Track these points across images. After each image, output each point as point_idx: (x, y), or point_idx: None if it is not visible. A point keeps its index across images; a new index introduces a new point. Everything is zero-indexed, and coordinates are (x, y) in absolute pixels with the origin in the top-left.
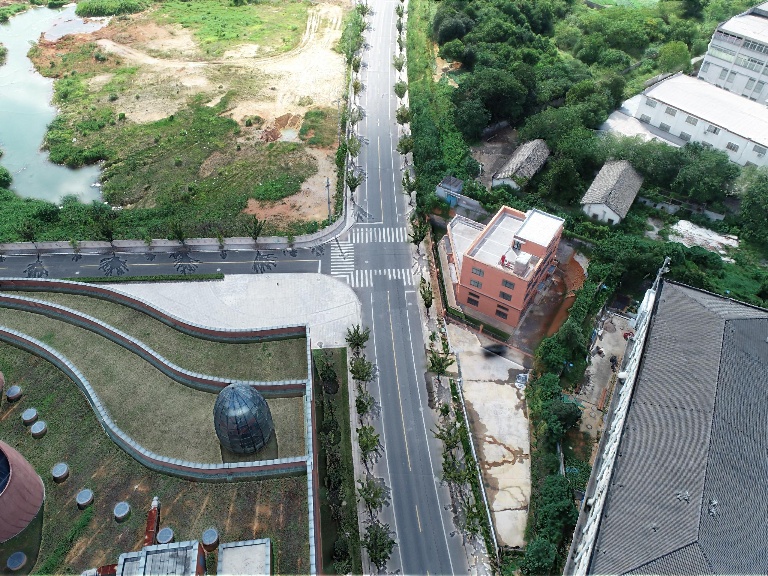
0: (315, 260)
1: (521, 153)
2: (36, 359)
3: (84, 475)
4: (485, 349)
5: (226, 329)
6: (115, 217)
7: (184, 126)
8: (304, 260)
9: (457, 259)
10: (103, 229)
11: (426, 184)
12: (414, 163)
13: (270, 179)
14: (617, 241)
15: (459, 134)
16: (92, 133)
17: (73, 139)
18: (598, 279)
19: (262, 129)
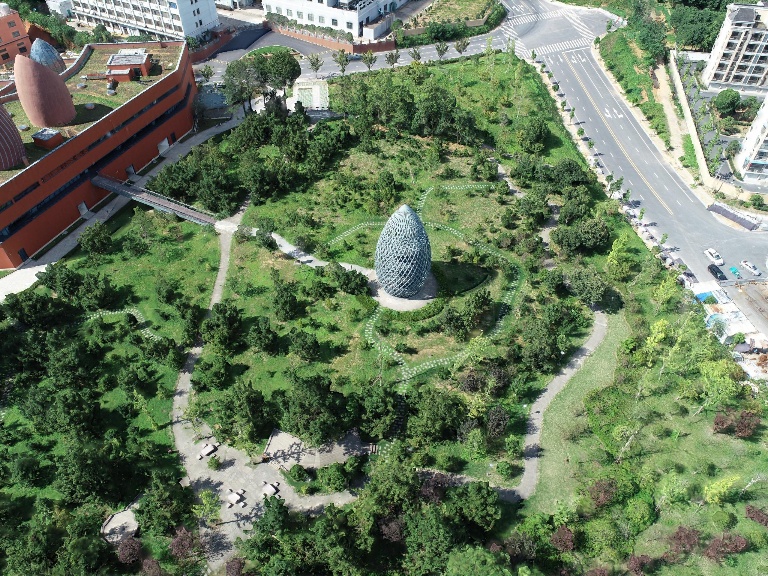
0: None
1: None
2: None
3: None
4: None
5: None
6: None
7: None
8: None
9: None
10: None
11: None
12: None
13: None
14: (6, 0)
15: None
16: None
17: None
18: (26, 14)
19: None
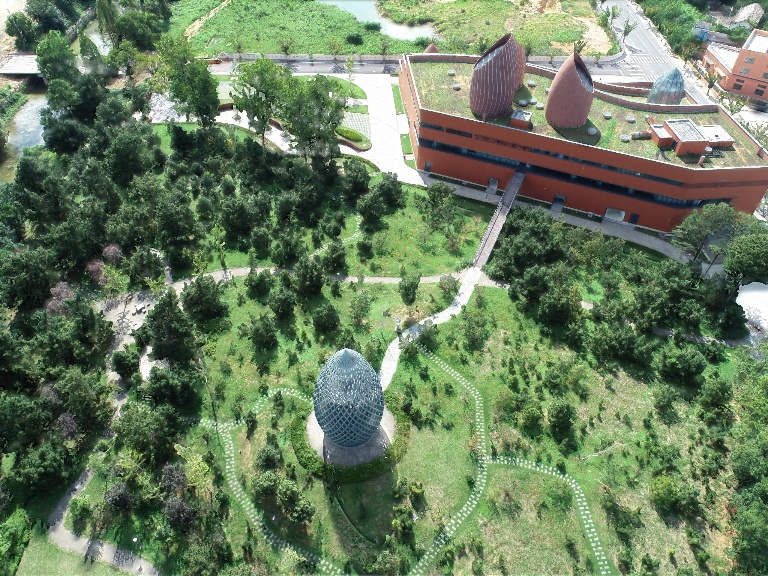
0: (617, 70)
1: (745, 10)
2: (529, 74)
3: (598, 110)
4: (753, 109)
5: (605, 82)
6: (468, 47)
7: (476, 4)
8: (609, 70)
9: (725, 61)
10: (482, 44)
11: (680, 29)
12: (657, 24)
13: (558, 32)
14: None
15: (689, 5)
16: (413, 7)
17: (402, 10)
18: None
19: (533, 7)
